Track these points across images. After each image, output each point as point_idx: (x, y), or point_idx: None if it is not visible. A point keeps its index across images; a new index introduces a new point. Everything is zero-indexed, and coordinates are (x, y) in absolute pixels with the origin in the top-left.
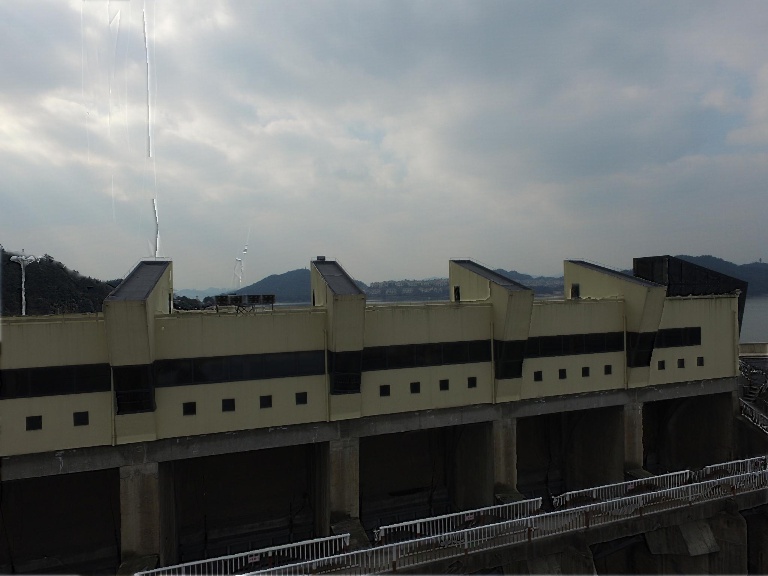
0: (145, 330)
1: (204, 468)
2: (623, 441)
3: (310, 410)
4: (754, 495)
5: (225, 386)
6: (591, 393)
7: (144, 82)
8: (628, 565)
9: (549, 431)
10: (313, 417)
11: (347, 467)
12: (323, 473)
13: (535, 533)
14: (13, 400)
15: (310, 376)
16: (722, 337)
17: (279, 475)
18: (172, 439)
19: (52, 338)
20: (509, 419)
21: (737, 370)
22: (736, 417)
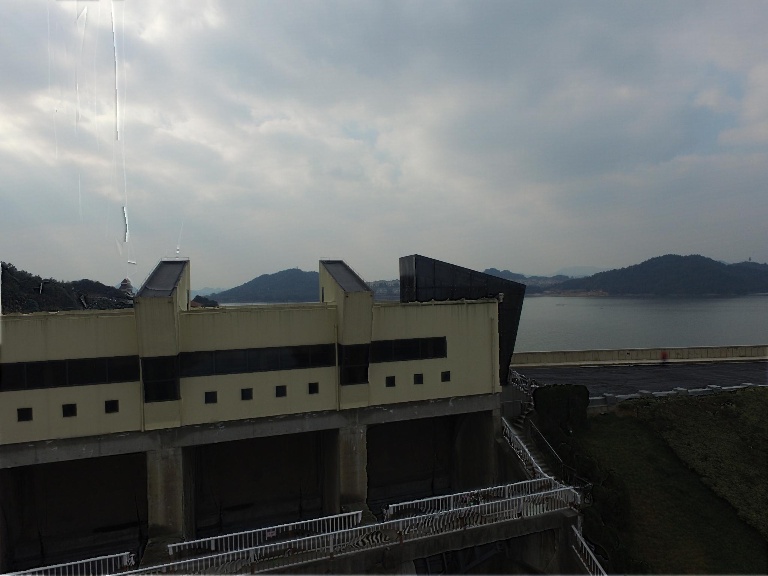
0: None
1: None
2: (339, 470)
3: None
4: (431, 541)
5: None
6: (291, 416)
7: (112, 79)
8: None
9: (317, 453)
10: None
11: None
12: None
13: None
14: None
15: None
16: (477, 348)
17: None
18: None
19: None
20: (171, 449)
21: (497, 386)
22: (496, 439)
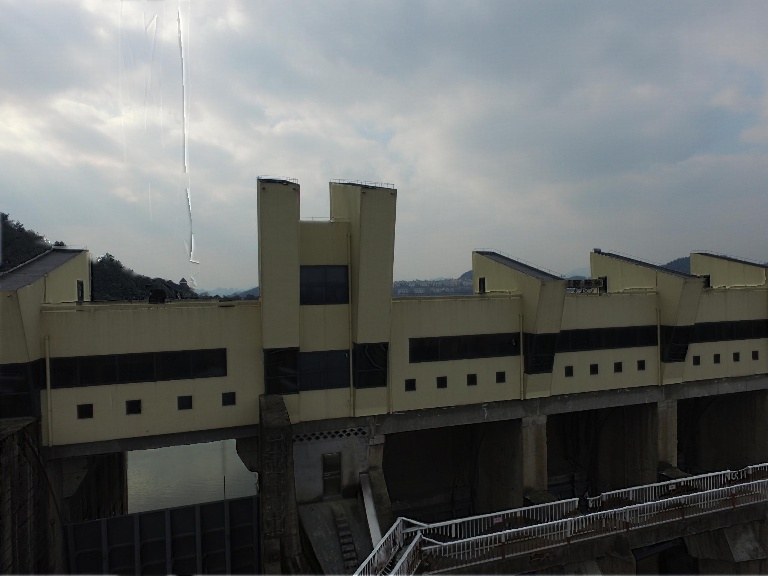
0: (562, 305)
1: None
2: None
3: (647, 375)
4: None
5: (591, 353)
6: None
7: (180, 85)
8: None
9: None
10: (649, 381)
11: (669, 424)
12: (634, 431)
13: None
14: (459, 361)
15: (647, 347)
16: None
17: None
18: (556, 396)
19: (482, 311)
20: None
21: None
22: None
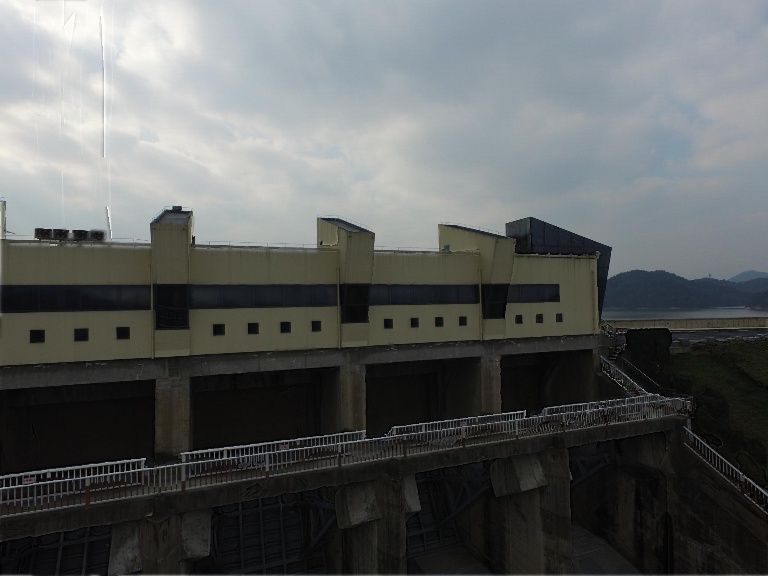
0: None
1: (51, 426)
2: (480, 392)
3: (133, 346)
4: (585, 432)
5: (34, 316)
6: (446, 343)
7: None
8: (485, 516)
9: (429, 395)
10: (136, 353)
11: (175, 407)
12: None
13: (346, 459)
14: None
15: (134, 311)
16: (581, 296)
17: (138, 436)
18: None
19: None
20: (358, 365)
21: (597, 328)
22: (596, 373)
